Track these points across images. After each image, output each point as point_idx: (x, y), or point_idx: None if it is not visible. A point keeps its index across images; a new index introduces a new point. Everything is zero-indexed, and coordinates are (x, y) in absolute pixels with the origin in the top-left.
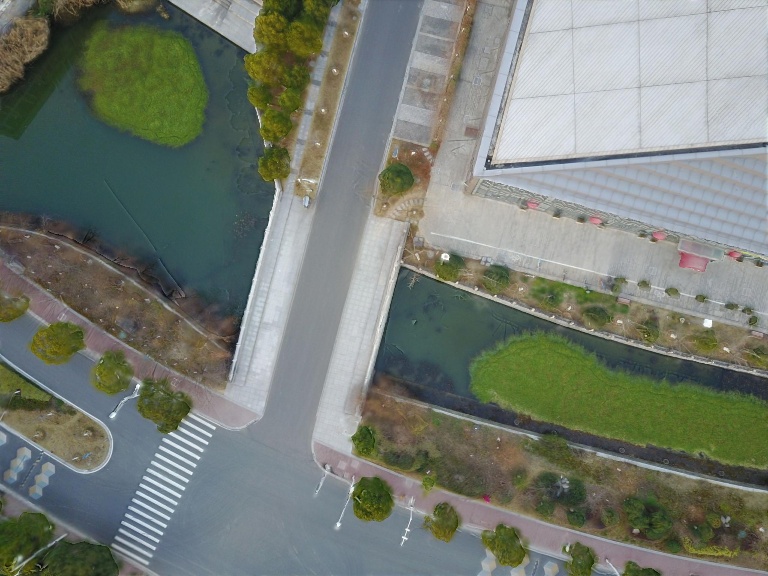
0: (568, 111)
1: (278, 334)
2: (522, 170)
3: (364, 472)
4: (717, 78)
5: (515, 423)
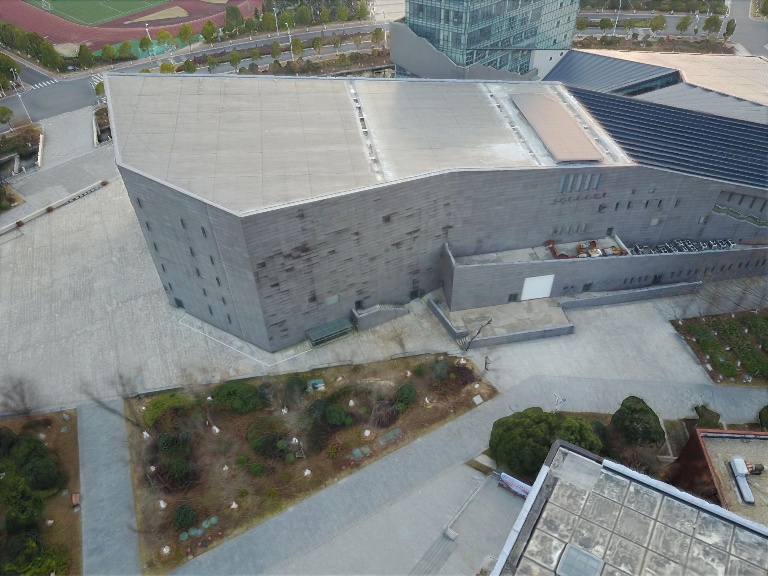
0: (746, 61)
1: None
2: None
3: None
4: None
5: None
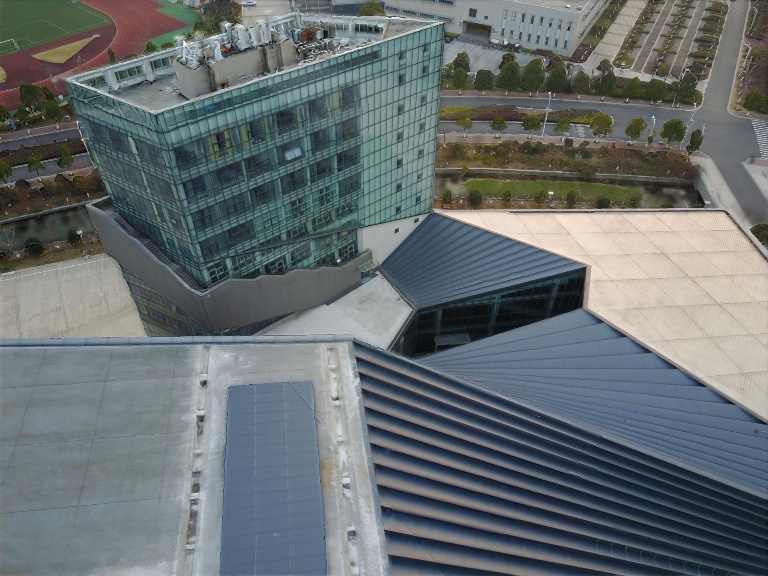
0: None
1: (762, 188)
2: (706, 209)
3: (677, 151)
4: None
5: (608, 180)
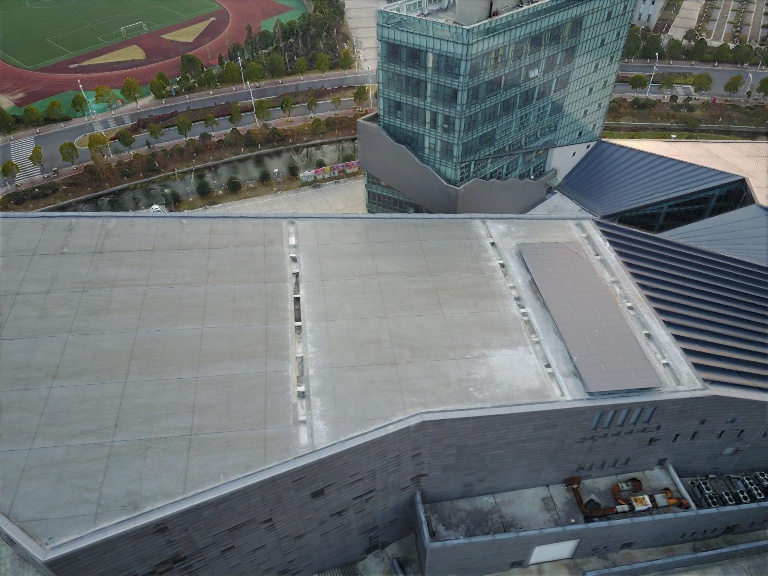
0: None
1: None
2: None
3: None
4: None
5: (712, 131)
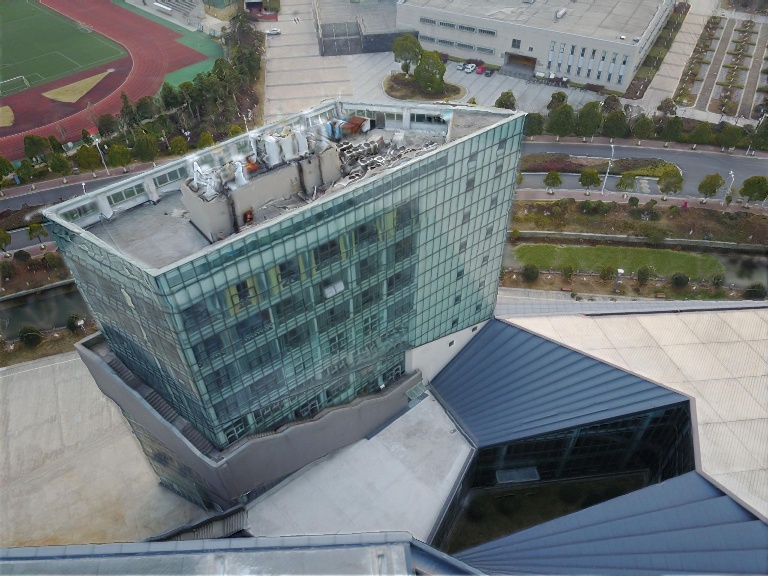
0: None
1: None
2: None
3: (758, 211)
4: (739, 342)
5: (680, 246)
